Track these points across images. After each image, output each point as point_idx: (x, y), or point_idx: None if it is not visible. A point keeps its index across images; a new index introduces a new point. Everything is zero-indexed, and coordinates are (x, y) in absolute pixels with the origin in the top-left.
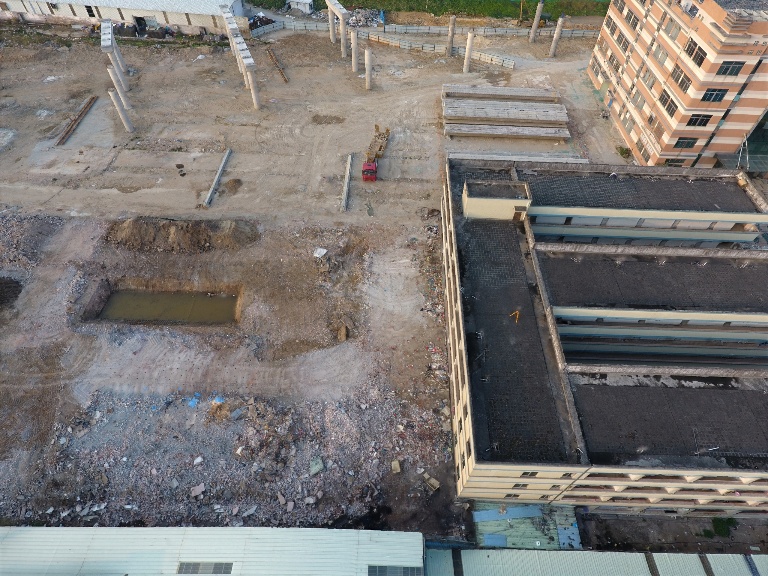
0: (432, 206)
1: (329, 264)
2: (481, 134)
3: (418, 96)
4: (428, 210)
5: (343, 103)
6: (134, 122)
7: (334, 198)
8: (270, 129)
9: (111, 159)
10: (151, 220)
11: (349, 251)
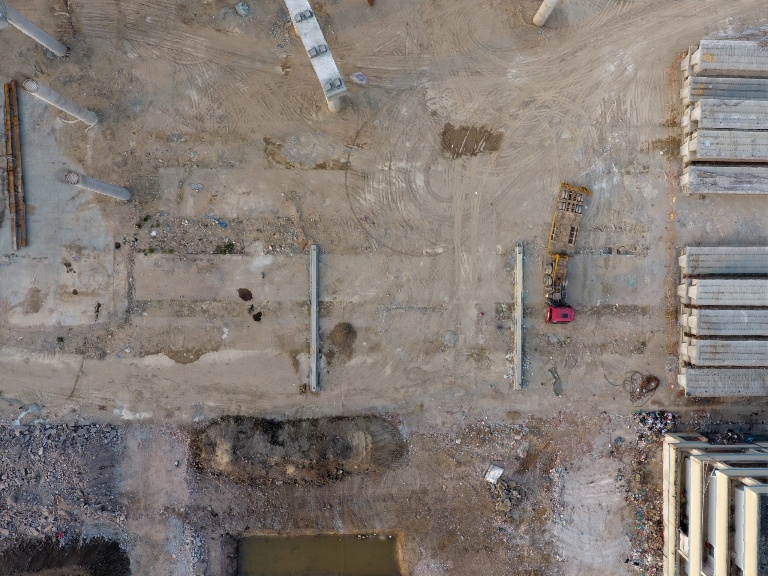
0: (648, 369)
1: (510, 499)
2: (749, 193)
3: (636, 45)
4: (642, 379)
5: (493, 80)
6: (121, 168)
7: (502, 359)
8: (371, 177)
9: (126, 282)
10: (255, 456)
11: (531, 464)
